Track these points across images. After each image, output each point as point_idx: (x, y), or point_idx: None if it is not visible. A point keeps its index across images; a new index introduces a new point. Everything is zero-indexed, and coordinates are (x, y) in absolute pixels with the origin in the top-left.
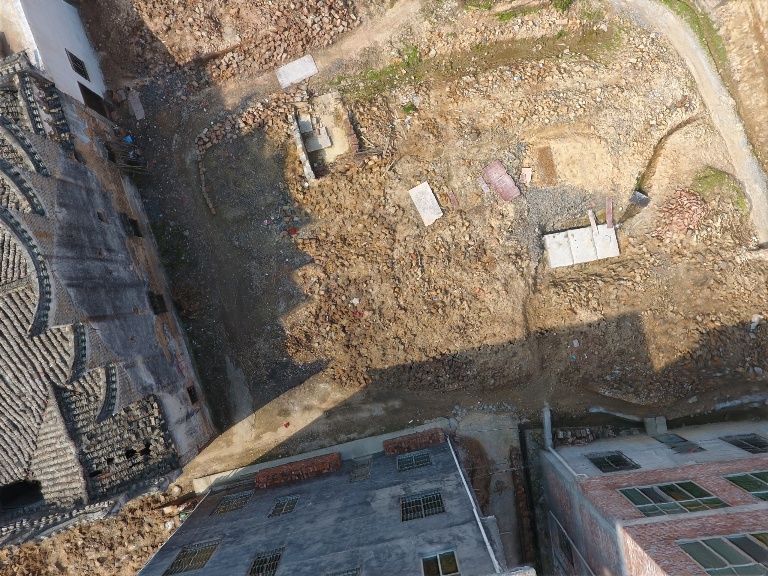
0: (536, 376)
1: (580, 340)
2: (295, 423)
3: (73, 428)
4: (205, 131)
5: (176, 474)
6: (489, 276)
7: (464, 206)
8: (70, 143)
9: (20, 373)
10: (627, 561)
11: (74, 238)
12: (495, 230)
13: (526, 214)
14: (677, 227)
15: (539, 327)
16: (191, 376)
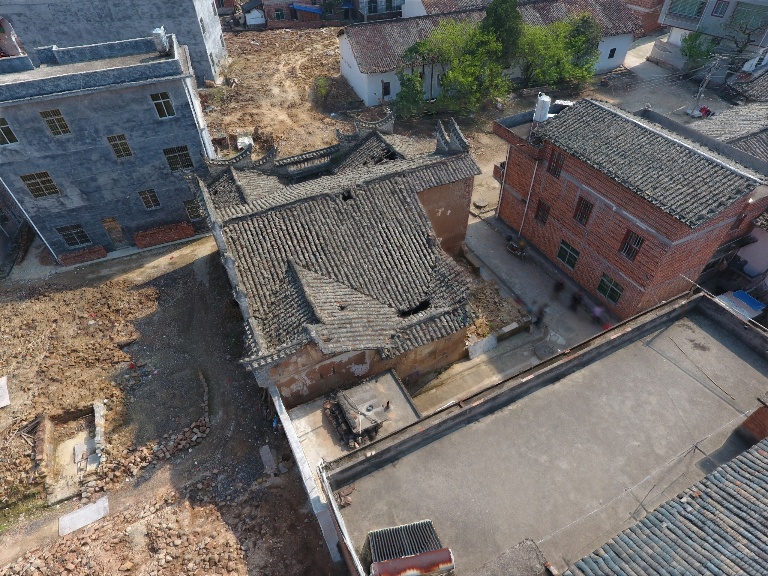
0: None
1: None
2: (166, 260)
3: (239, 191)
4: (195, 437)
5: None
6: None
7: None
8: (245, 339)
9: None
10: None
11: None
12: None
13: None
14: None
15: None
16: None
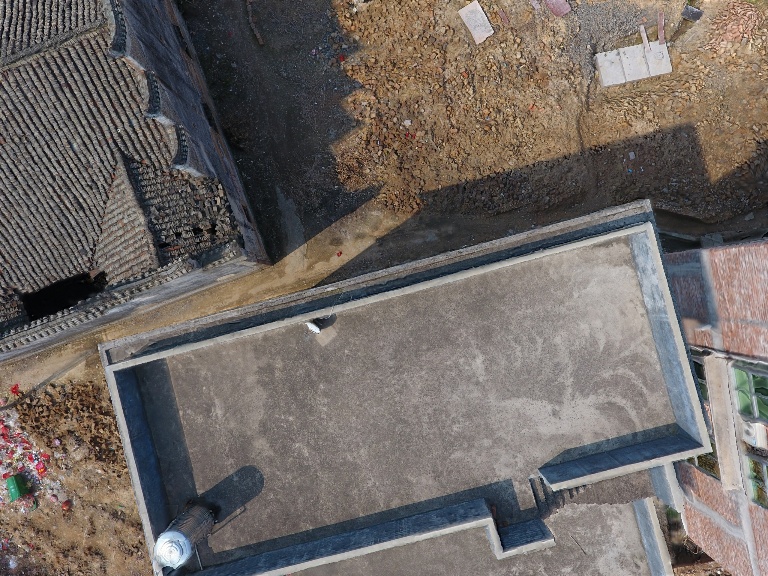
0: (591, 195)
1: (636, 152)
2: (347, 252)
3: (141, 198)
4: None
5: (243, 251)
6: (542, 92)
7: (515, 24)
8: None
9: (88, 139)
10: (715, 283)
11: (139, 8)
12: (547, 47)
13: (577, 30)
14: (732, 35)
15: (593, 145)
16: (244, 200)
